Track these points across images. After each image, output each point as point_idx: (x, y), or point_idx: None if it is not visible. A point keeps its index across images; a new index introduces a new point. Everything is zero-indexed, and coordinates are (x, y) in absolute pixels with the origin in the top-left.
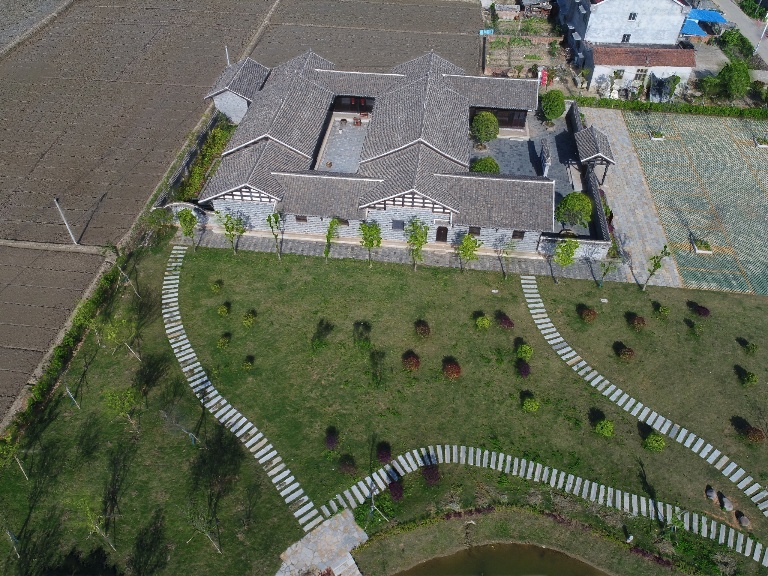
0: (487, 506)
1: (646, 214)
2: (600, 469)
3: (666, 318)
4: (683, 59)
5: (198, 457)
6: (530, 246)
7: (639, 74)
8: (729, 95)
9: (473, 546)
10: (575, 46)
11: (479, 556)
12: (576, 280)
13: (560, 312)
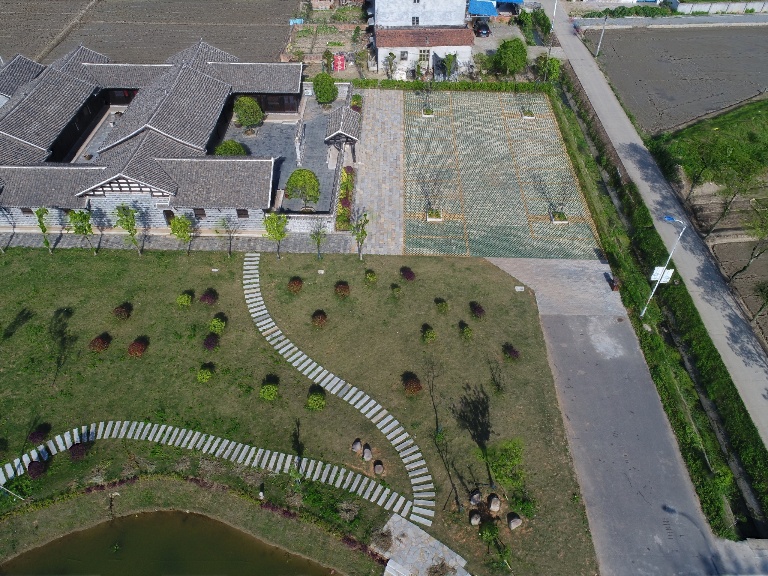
0: (132, 477)
1: (392, 187)
2: (256, 432)
3: (374, 284)
4: (462, 38)
5: None
6: (258, 224)
7: (423, 55)
8: (513, 71)
9: (116, 517)
10: (374, 31)
11: (121, 526)
12: (300, 254)
13: (273, 286)
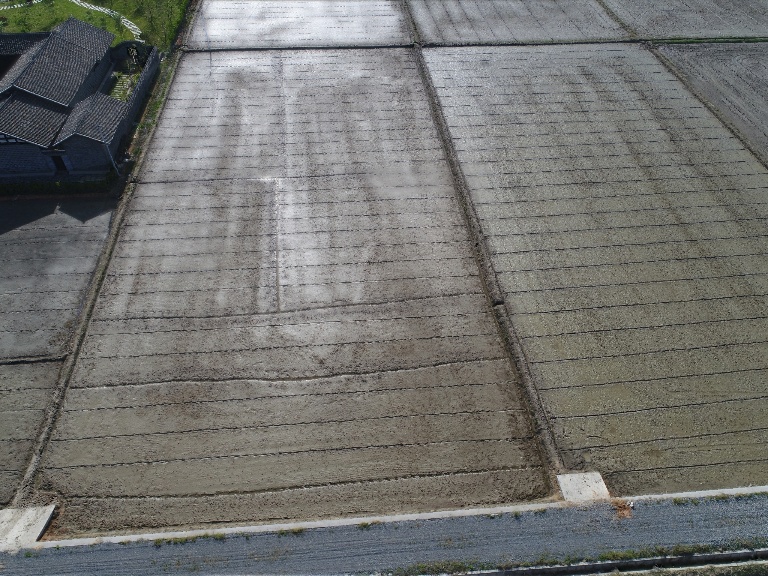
0: None
1: None
2: None
3: None
4: None
5: None
6: None
7: None
8: None
9: None
10: None
11: None
12: None
13: None
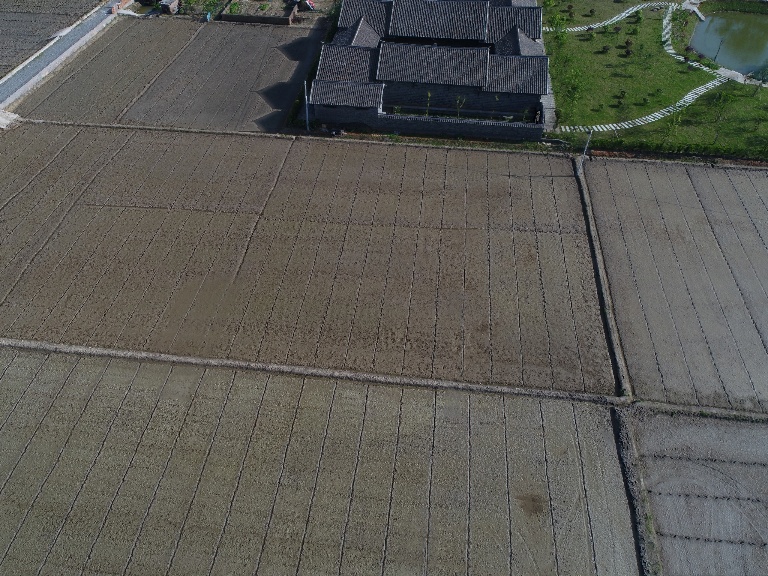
0: None
1: None
2: None
3: (561, 5)
4: None
5: None
6: None
7: None
8: None
9: None
10: None
11: None
12: None
13: None
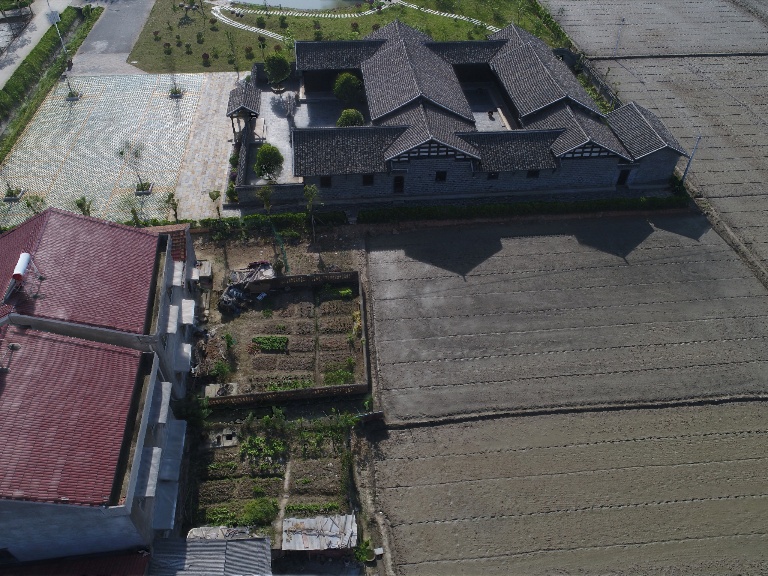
0: None
1: (207, 110)
2: None
3: None
4: None
5: (454, 5)
6: None
7: None
8: None
9: None
10: None
11: None
12: None
13: (294, 56)
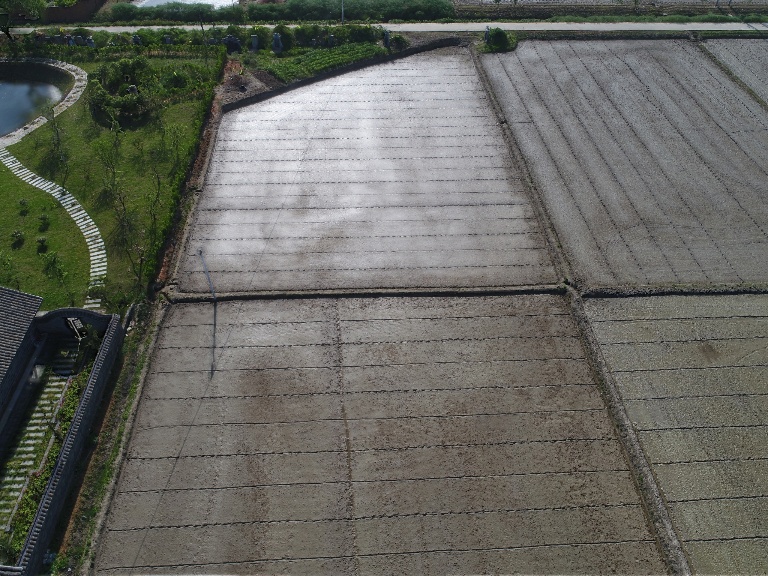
0: None
1: None
2: None
3: None
4: None
5: None
6: None
7: None
8: None
9: None
10: None
11: None
12: None
13: None
